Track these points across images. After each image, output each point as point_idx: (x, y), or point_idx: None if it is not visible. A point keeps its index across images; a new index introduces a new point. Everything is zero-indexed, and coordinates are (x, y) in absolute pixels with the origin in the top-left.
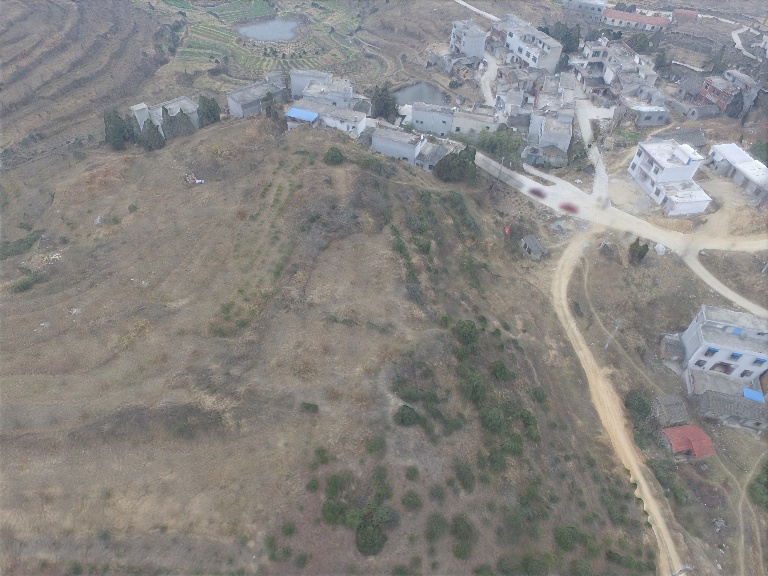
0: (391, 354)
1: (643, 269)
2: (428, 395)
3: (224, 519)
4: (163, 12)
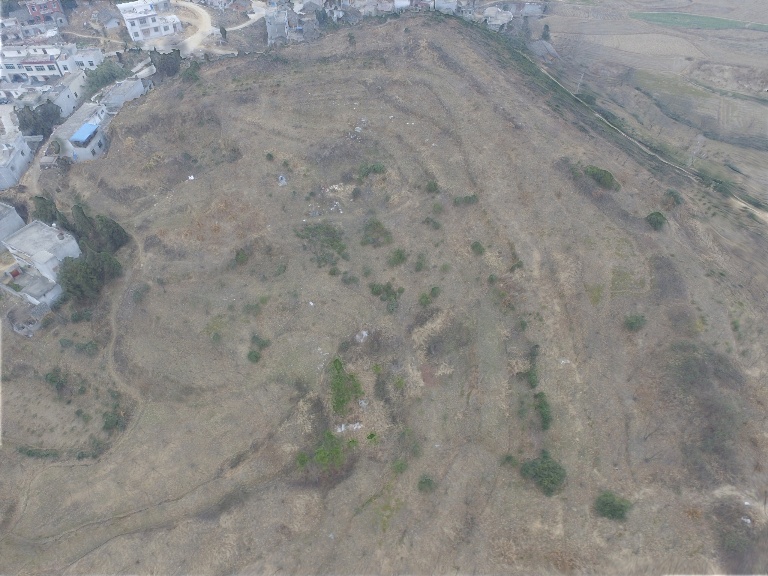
0: None
1: (230, 41)
2: None
3: None
4: None
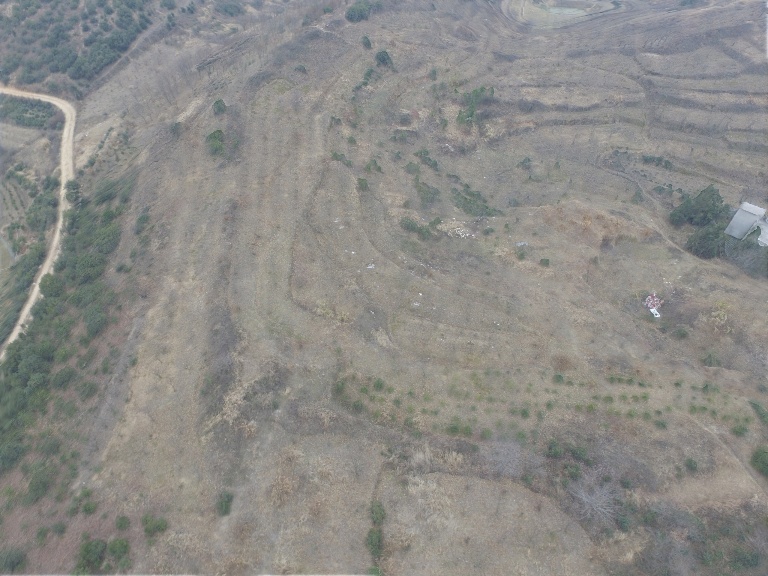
0: None
1: None
2: None
3: (122, 447)
4: None
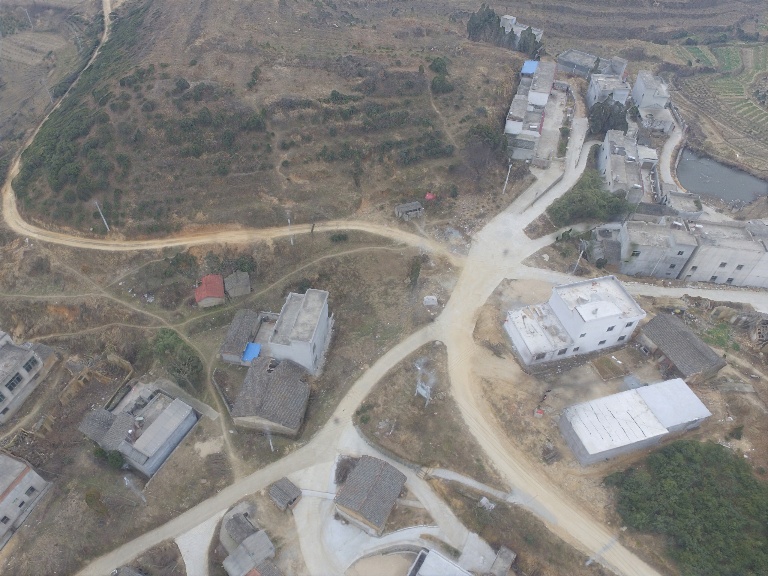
0: (230, 87)
1: (406, 294)
2: (196, 92)
3: None
4: None
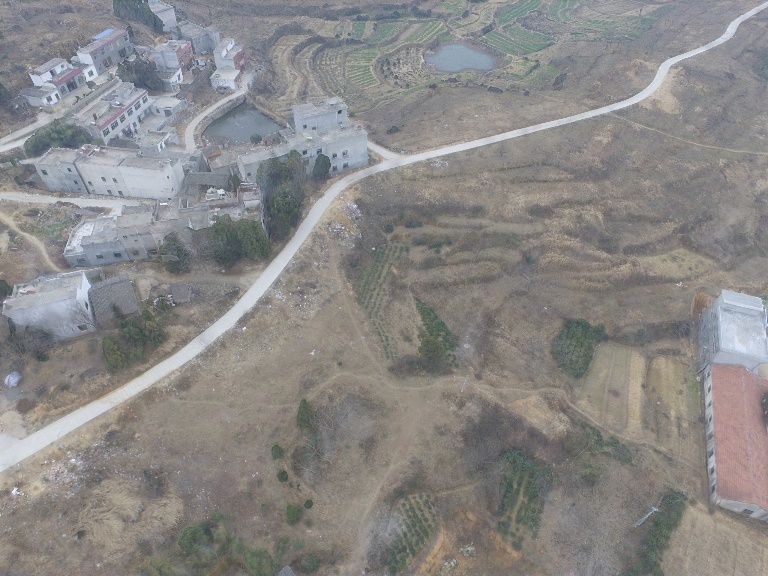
0: None
1: None
2: None
3: None
4: (458, 4)
